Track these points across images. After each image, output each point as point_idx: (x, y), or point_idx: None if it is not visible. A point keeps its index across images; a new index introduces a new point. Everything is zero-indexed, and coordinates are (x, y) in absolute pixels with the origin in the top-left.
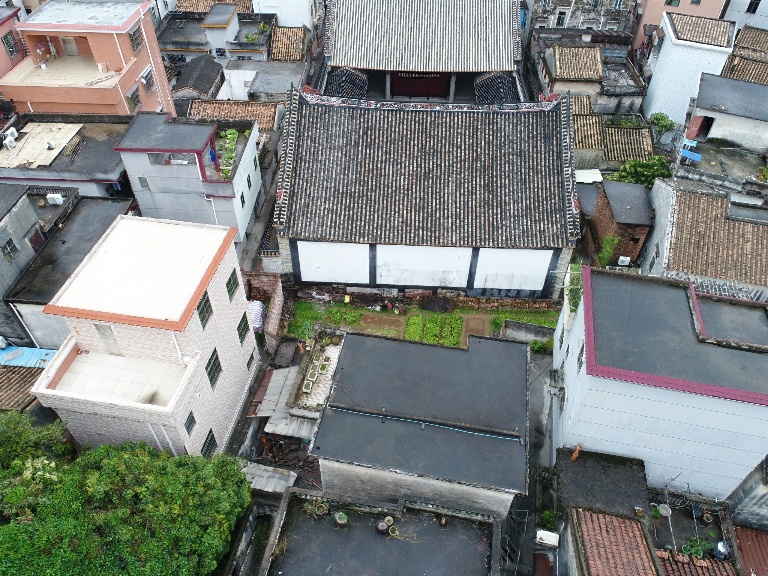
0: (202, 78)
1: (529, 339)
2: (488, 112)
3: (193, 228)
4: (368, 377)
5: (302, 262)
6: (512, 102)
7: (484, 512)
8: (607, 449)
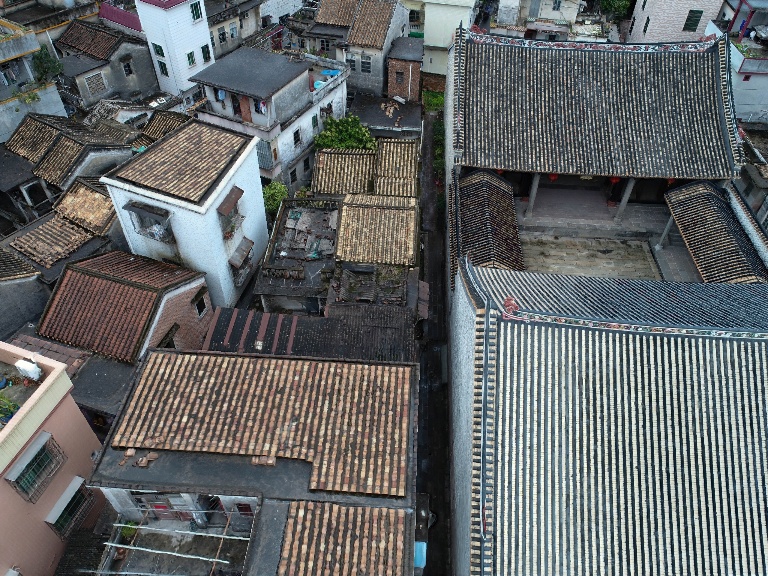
0: None
1: None
2: None
3: None
4: None
5: None
6: None
7: None
8: None
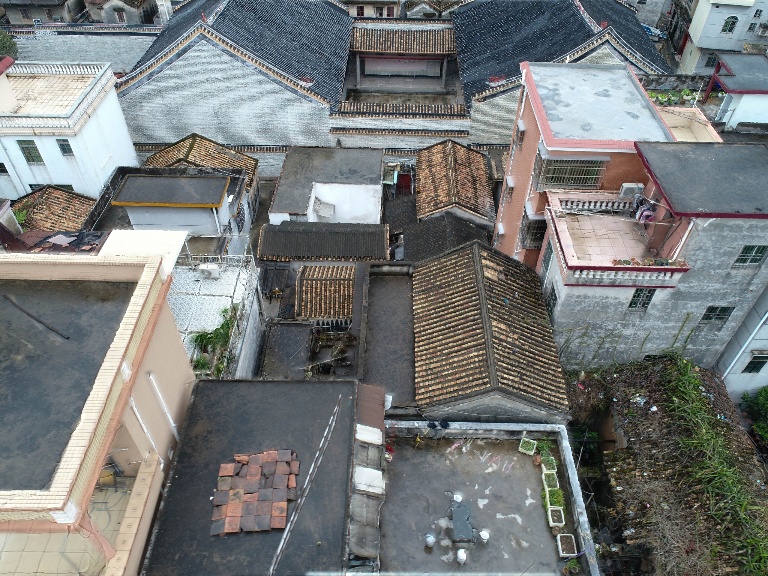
0: (345, 227)
1: None
2: None
3: None
4: None
5: None
6: None
7: None
8: None
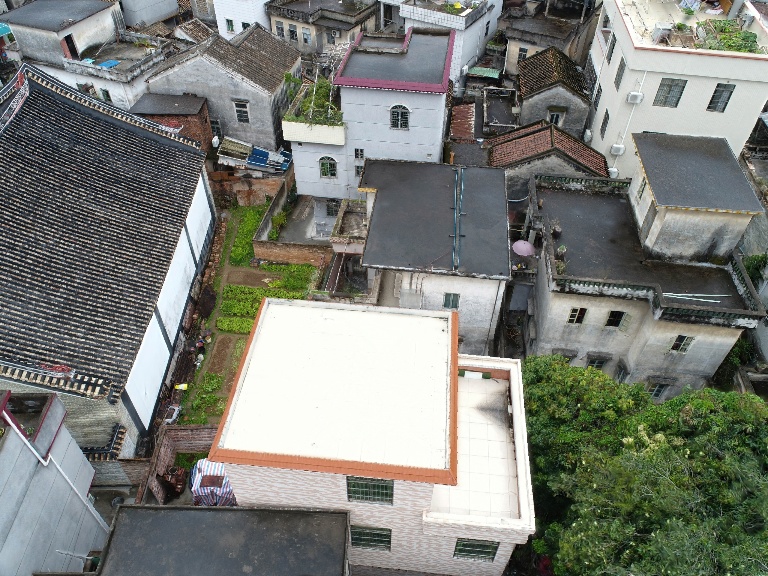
0: None
1: (266, 238)
2: (0, 135)
3: (260, 344)
4: (417, 247)
5: (137, 408)
6: (4, 108)
7: (533, 178)
8: (438, 155)
